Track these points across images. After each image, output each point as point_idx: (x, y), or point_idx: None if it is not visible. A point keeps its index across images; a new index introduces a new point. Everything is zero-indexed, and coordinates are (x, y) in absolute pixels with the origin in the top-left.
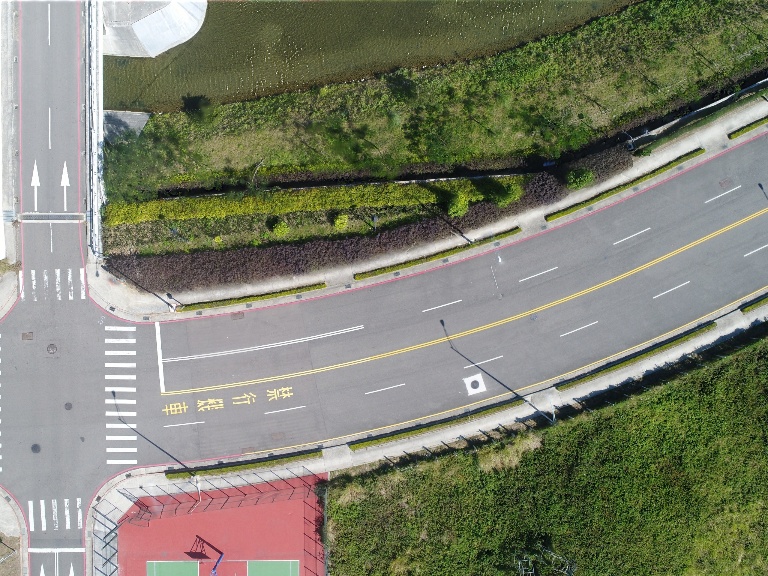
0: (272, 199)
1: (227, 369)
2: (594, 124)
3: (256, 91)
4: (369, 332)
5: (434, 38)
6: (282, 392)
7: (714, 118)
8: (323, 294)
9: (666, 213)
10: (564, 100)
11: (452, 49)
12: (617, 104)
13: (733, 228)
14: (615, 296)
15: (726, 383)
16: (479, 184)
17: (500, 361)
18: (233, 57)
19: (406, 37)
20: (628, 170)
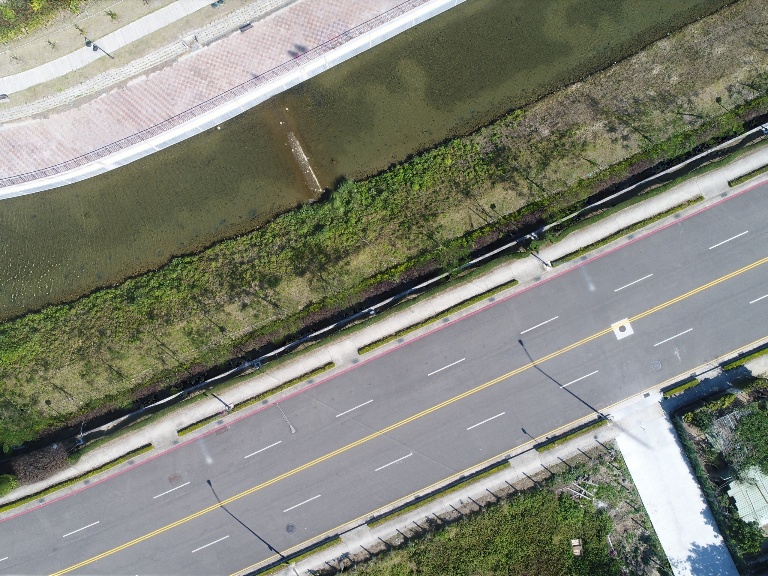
0: None
1: None
2: (62, 410)
3: None
4: None
5: None
6: None
7: (149, 422)
8: None
9: (115, 507)
10: (30, 387)
11: None
12: (83, 391)
13: (181, 524)
14: None
15: None
16: None
17: None
18: None
19: None
20: (77, 465)
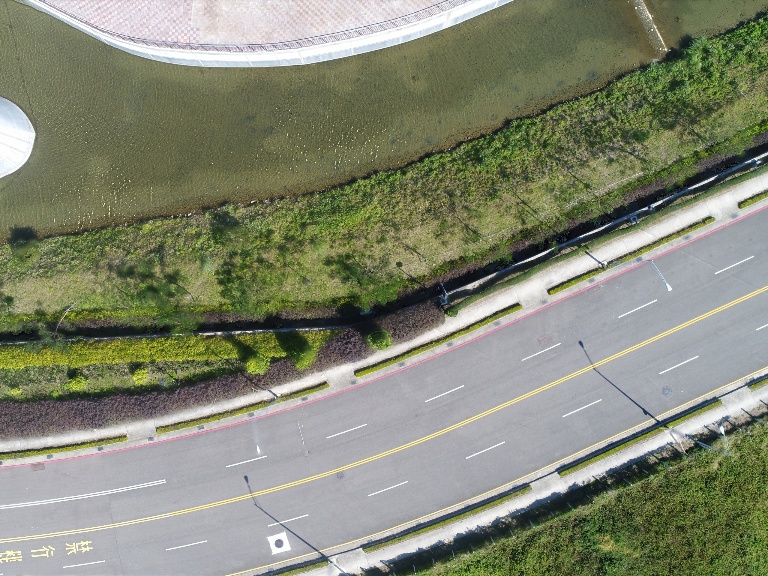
0: (70, 352)
1: (26, 521)
2: (413, 272)
3: (83, 223)
4: (171, 487)
5: (264, 172)
6: (81, 546)
7: (527, 276)
8: (125, 446)
9: (481, 370)
10: (381, 248)
11: (282, 183)
12: (437, 252)
13: (551, 387)
14: (426, 455)
15: (539, 551)
16: (283, 339)
17: (305, 520)
18: (61, 188)
19: (236, 170)
20: (441, 325)
